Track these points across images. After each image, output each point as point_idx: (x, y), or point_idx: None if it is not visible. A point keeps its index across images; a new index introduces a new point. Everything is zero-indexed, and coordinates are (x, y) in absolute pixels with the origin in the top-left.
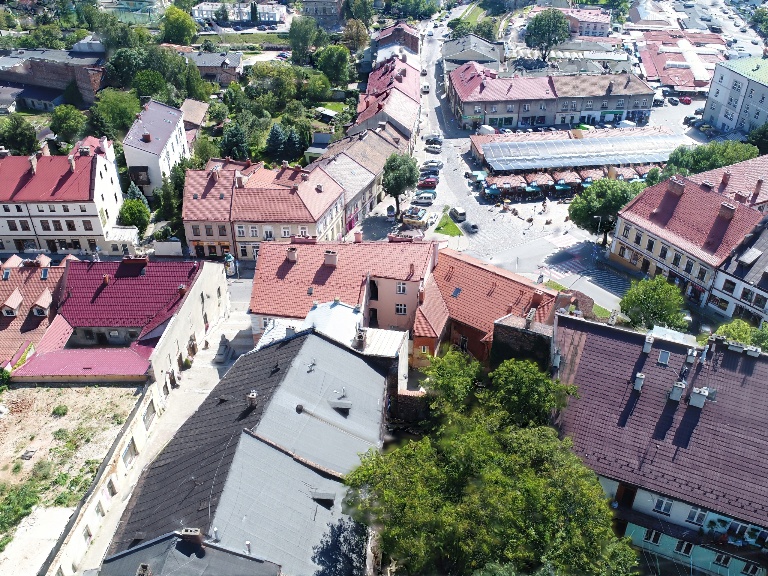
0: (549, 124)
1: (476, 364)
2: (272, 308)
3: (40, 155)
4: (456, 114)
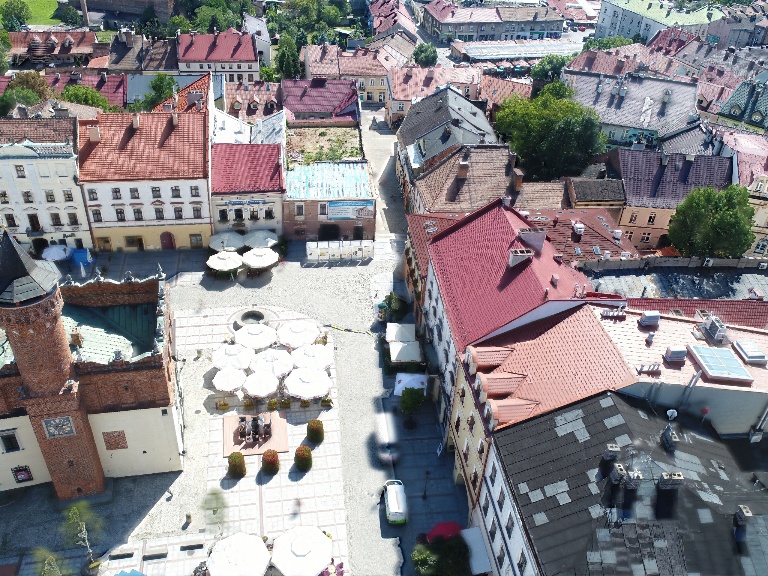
0: (497, 40)
1: (526, 98)
2: (405, 98)
3: (218, 34)
4: (433, 34)
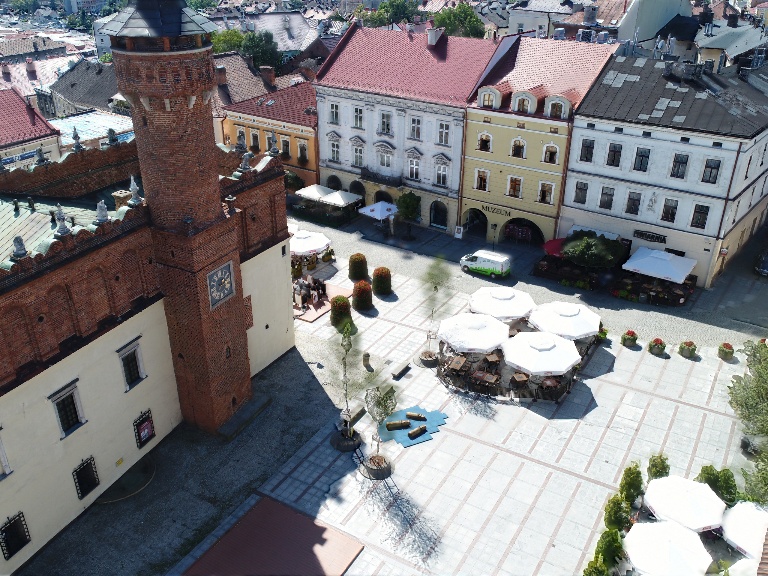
0: None
1: None
2: None
3: None
4: None
